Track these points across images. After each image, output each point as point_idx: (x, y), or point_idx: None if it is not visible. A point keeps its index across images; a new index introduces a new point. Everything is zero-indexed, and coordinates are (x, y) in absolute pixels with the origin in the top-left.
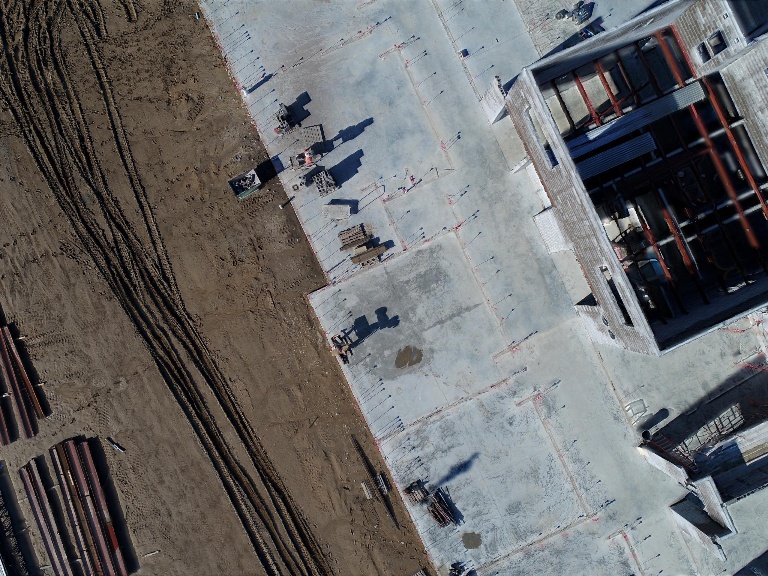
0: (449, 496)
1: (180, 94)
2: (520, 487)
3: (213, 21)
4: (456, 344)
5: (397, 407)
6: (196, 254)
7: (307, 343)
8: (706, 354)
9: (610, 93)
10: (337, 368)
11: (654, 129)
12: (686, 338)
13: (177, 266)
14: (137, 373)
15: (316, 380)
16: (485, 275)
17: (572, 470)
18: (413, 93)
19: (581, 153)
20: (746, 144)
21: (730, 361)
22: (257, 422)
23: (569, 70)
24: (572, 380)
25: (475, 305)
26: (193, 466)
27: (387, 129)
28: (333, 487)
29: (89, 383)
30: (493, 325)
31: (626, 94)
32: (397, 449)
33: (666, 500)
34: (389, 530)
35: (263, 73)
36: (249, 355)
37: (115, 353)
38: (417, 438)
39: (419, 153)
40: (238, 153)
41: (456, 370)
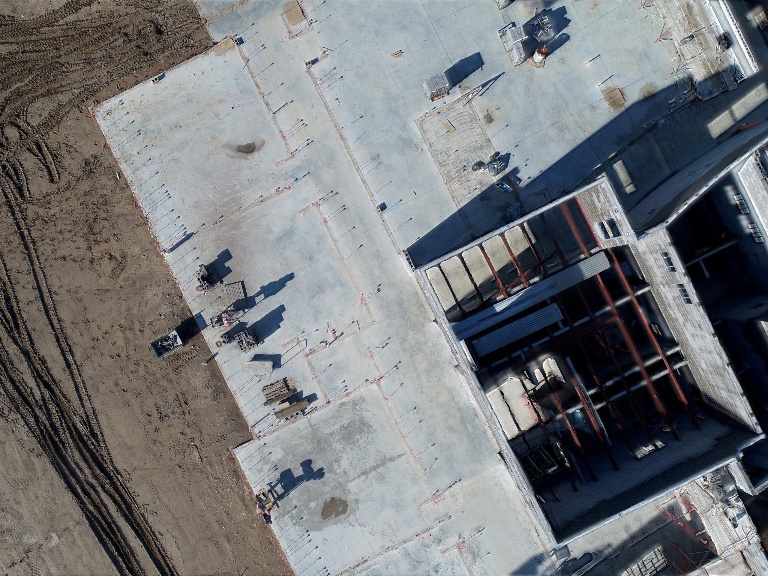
0: None
1: (103, 253)
2: None
3: (133, 181)
4: (381, 494)
5: (324, 558)
6: (123, 410)
7: (234, 496)
8: None
9: (516, 265)
10: None
11: (561, 299)
12: (583, 530)
13: (105, 422)
14: (68, 529)
15: (244, 532)
16: (408, 425)
17: None
18: (333, 247)
19: (489, 325)
20: (655, 306)
21: (652, 504)
22: (187, 574)
23: None
24: (496, 527)
25: (399, 455)
26: None
27: (308, 284)
28: None
29: (21, 539)
30: (417, 475)
31: (544, 243)
32: None
33: None
34: None
35: (184, 232)
36: (178, 509)
37: (46, 509)
38: None
39: (340, 307)
40: (162, 310)
41: (381, 520)
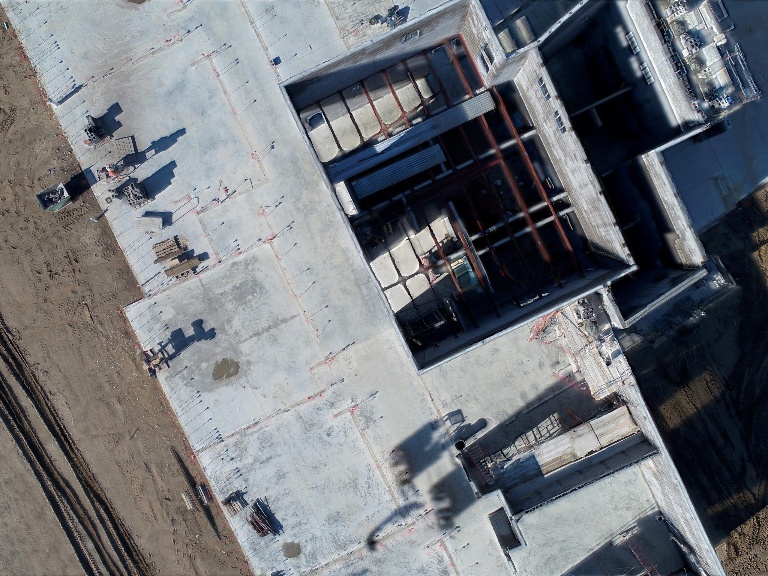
0: (268, 506)
1: None
2: (338, 497)
3: (21, 31)
4: (273, 356)
5: (215, 419)
6: (13, 268)
7: (125, 356)
8: (524, 364)
9: (399, 104)
10: (155, 380)
11: (444, 141)
12: (445, 357)
13: None
14: None
15: (135, 392)
16: (301, 286)
17: (390, 480)
18: (226, 103)
19: (369, 166)
20: (544, 154)
21: (549, 370)
22: (78, 434)
23: (355, 81)
24: (390, 391)
25: (291, 317)
26: (16, 478)
27: (200, 140)
28: (154, 498)
29: None
30: (310, 336)
31: (443, 101)
32: (215, 460)
33: (484, 509)
34: (210, 539)
35: (73, 84)
36: (68, 368)
37: None
38: (235, 449)
39: (233, 164)
40: (51, 166)
41: (273, 382)
